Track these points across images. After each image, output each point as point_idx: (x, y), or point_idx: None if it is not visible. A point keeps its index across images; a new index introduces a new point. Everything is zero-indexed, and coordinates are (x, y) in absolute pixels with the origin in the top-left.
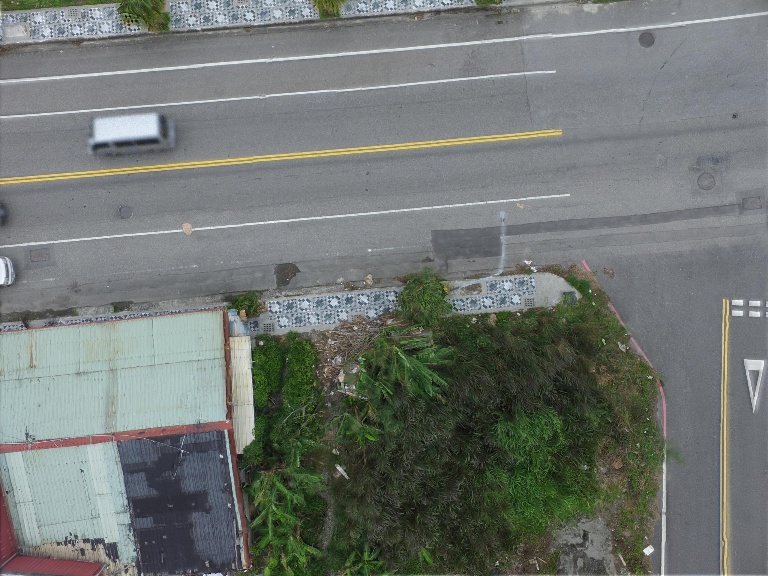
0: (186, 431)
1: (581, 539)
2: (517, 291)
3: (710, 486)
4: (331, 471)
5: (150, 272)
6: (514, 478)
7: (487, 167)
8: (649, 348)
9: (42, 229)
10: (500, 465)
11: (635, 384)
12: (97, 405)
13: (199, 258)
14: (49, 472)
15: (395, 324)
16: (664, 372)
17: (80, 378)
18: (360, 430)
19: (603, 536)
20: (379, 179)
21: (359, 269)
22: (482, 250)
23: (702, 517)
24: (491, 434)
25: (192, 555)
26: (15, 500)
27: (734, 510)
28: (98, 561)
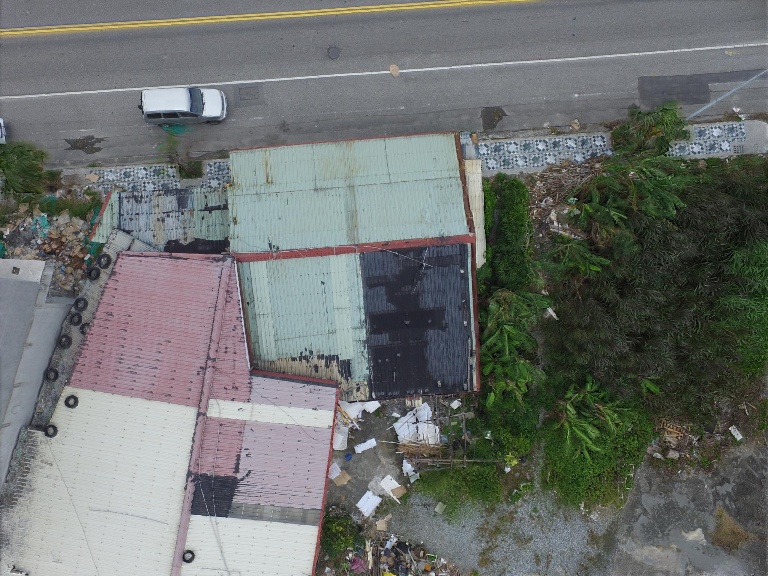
0: (429, 243)
1: None
2: (726, 137)
3: None
4: (540, 312)
5: (357, 113)
6: (749, 304)
7: (696, 13)
8: None
9: (251, 67)
10: (733, 292)
11: None
12: (337, 219)
13: (406, 100)
14: (290, 283)
15: (605, 166)
16: None
17: (317, 194)
18: (585, 260)
19: None
20: (586, 24)
21: (566, 114)
22: (689, 97)
23: None
24: (723, 262)
25: (424, 375)
26: (255, 311)
27: None
28: (330, 379)
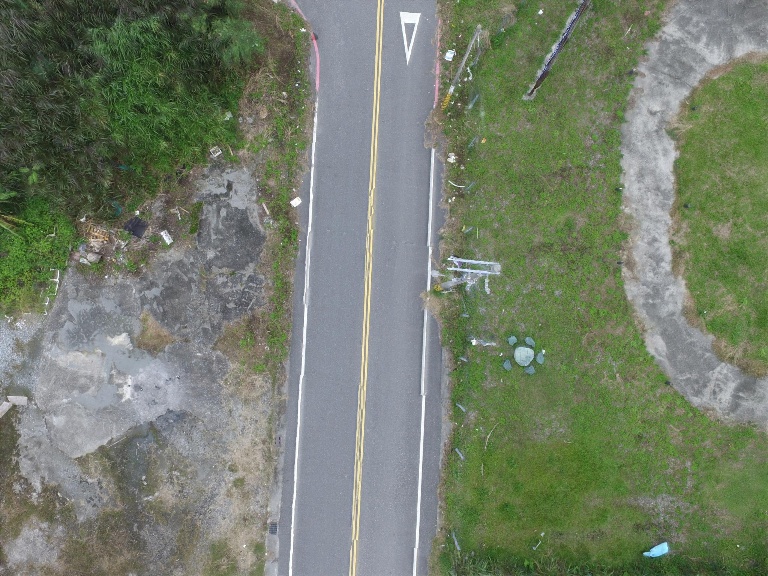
0: None
1: (225, 189)
2: None
3: (361, 138)
4: None
5: None
6: None
7: None
8: (303, 0)
9: None
10: None
11: (287, 36)
12: None
13: None
14: None
15: None
16: (318, 25)
17: None
18: None
19: (247, 186)
20: None
21: None
22: None
23: (351, 169)
24: None
25: None
26: None
27: (384, 161)
28: None
